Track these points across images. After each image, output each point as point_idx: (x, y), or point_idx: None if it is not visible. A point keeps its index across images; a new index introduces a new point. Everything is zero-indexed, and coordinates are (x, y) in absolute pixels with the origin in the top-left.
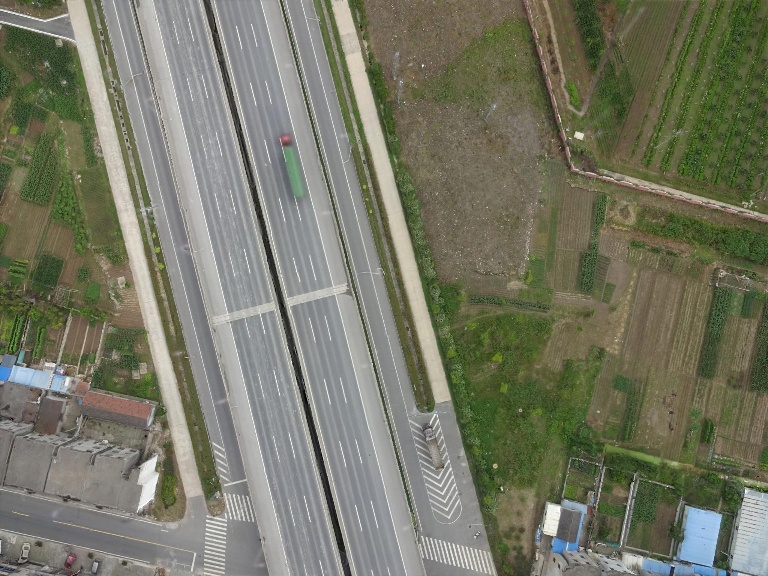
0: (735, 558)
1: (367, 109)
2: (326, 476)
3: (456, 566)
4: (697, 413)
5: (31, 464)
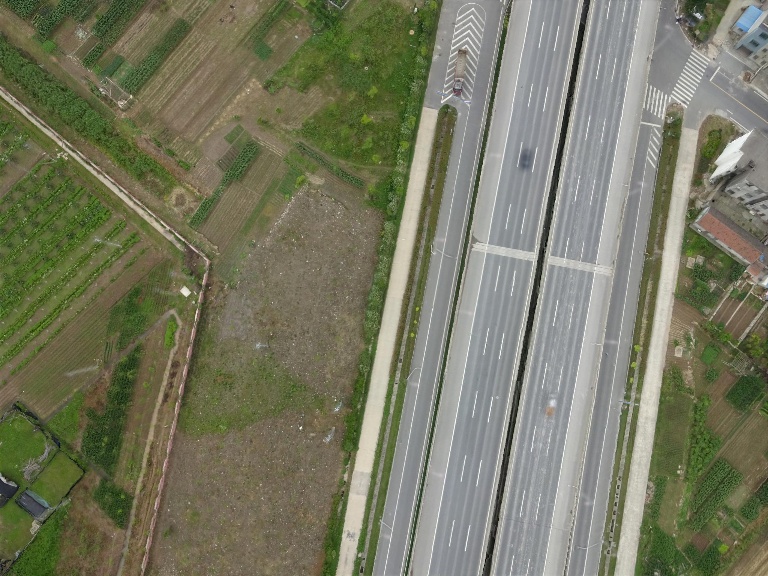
0: None
1: (374, 410)
2: None
3: None
4: None
5: None
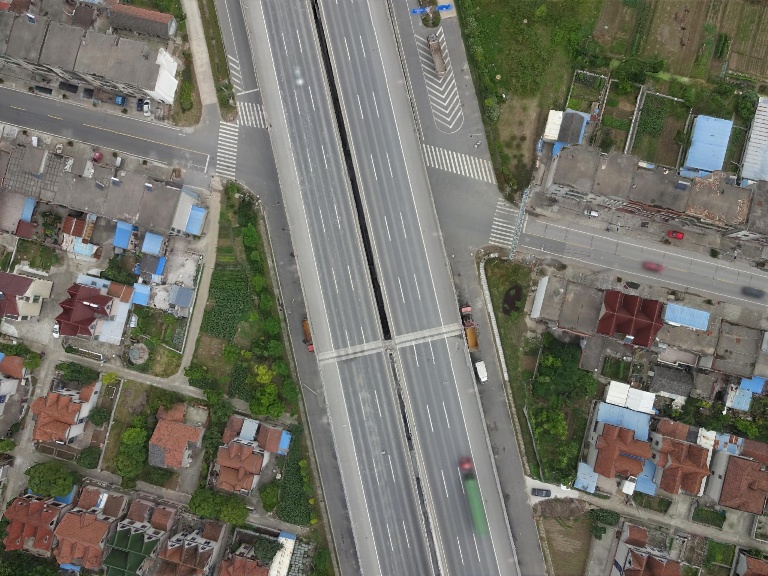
0: (746, 166)
1: None
2: (332, 84)
3: (456, 173)
4: (711, 28)
5: (63, 45)
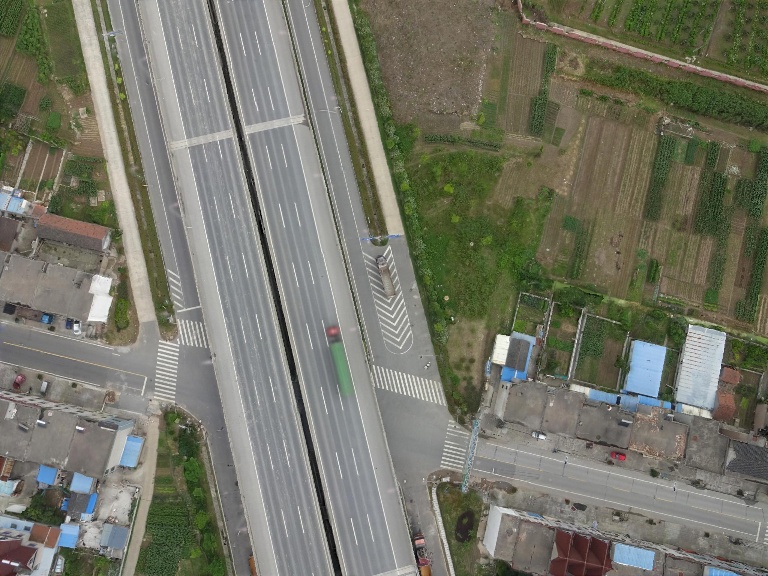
0: (680, 390)
1: None
2: (279, 303)
3: (407, 395)
4: (643, 253)
5: None
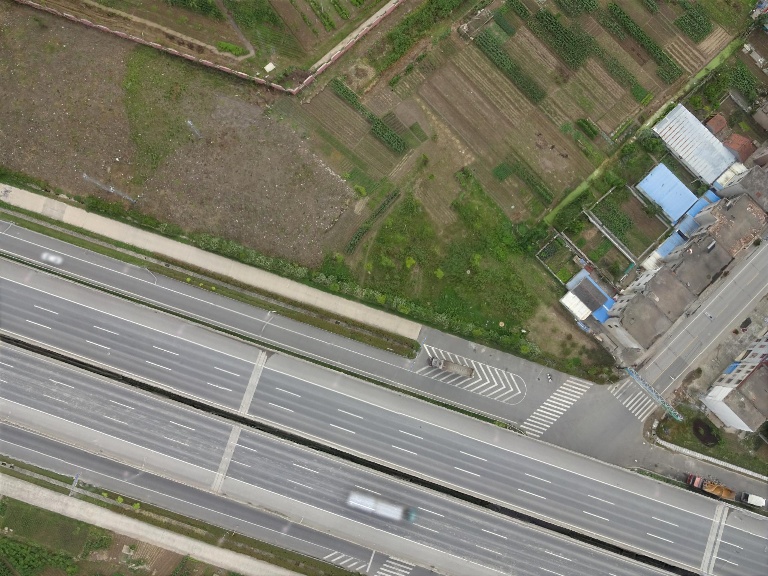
0: (703, 175)
1: (122, 233)
2: None
3: (564, 413)
4: (566, 126)
5: None
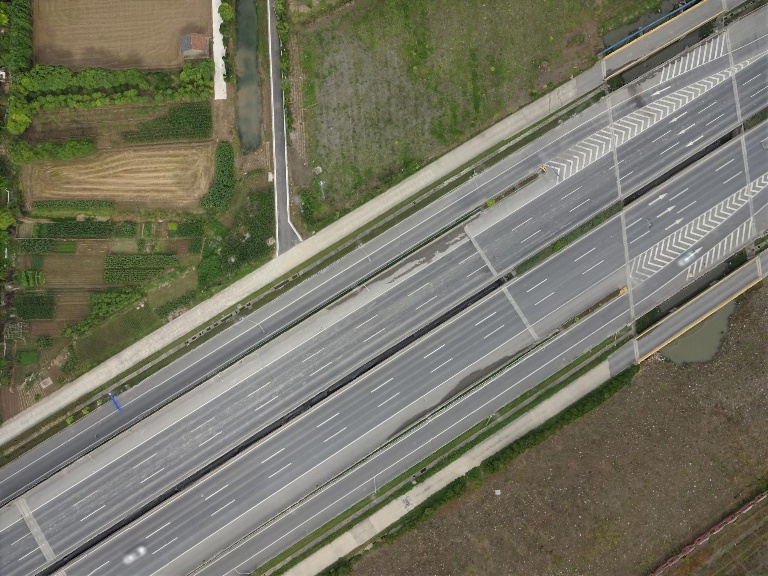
0: None
1: (300, 573)
2: None
3: None
4: None
5: None
